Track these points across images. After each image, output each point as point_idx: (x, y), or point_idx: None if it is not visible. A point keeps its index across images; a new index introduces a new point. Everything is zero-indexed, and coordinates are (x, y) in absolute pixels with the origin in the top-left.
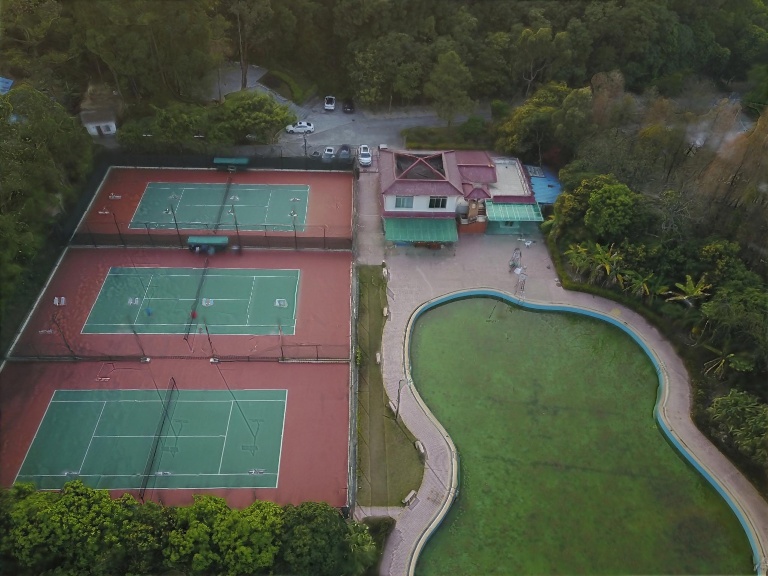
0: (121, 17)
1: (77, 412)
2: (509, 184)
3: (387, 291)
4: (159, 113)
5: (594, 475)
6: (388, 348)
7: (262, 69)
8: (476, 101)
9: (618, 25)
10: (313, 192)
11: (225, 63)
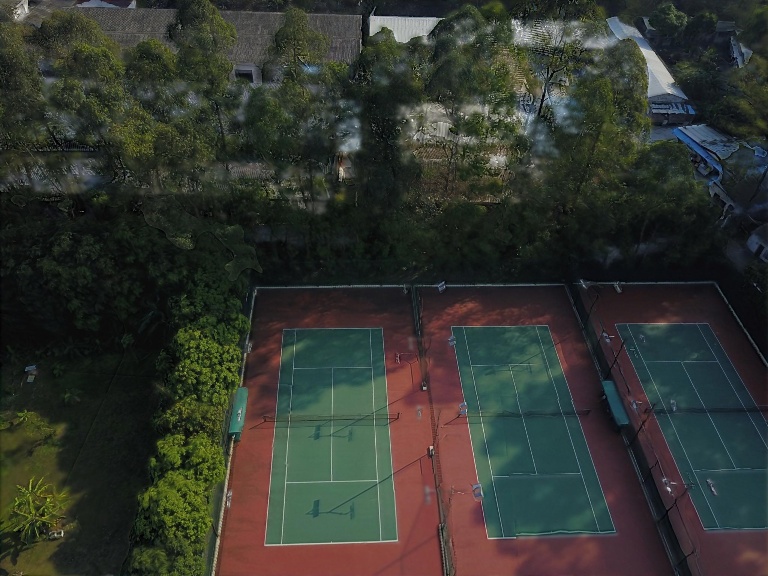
0: None
1: (359, 349)
2: None
3: None
4: None
5: None
6: None
7: None
8: None
9: None
10: None
11: None
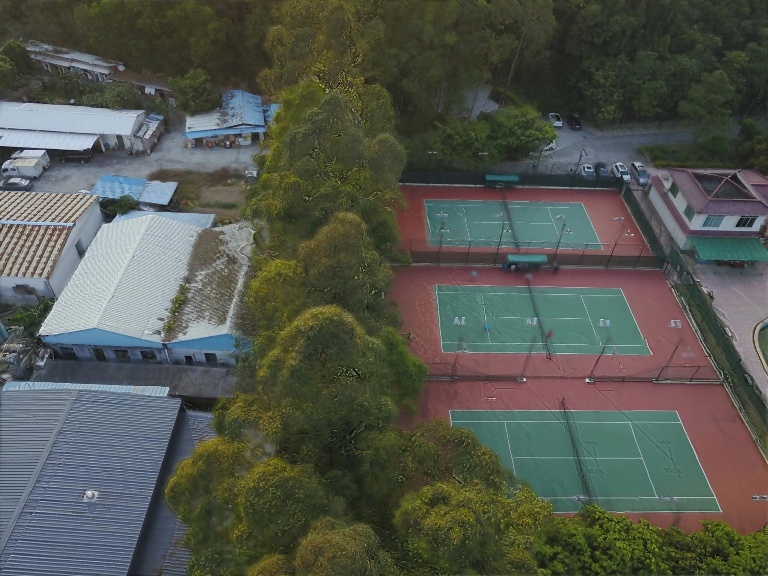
0: (433, 36)
1: (483, 433)
2: None
3: (716, 311)
4: (443, 130)
5: None
6: (750, 369)
7: None
8: (730, 120)
9: None
10: (590, 210)
11: (487, 81)
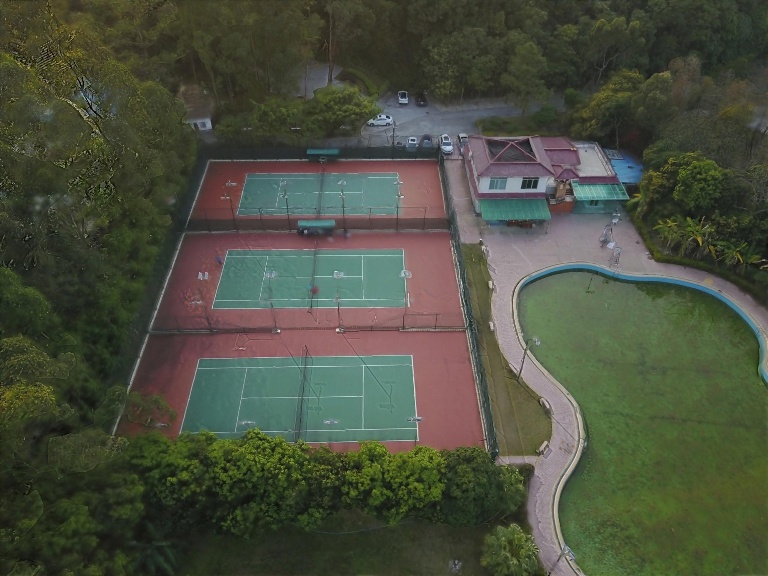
0: (229, 18)
1: (223, 377)
2: (591, 166)
3: (488, 267)
4: (258, 108)
5: (710, 427)
6: (499, 317)
7: (337, 67)
8: (551, 90)
9: (681, 14)
10: (403, 179)
11: (313, 60)
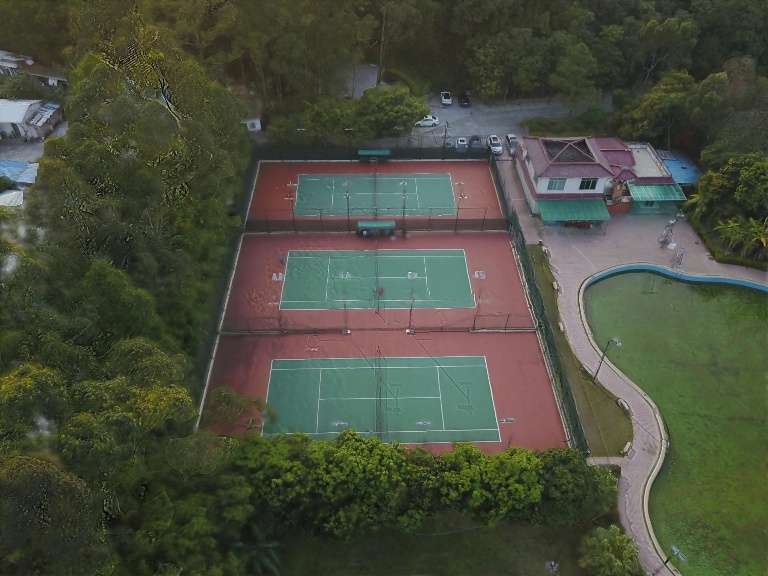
0: (287, 19)
1: (298, 378)
2: (645, 167)
3: (550, 267)
4: (311, 108)
5: None
6: (567, 318)
7: None
8: (599, 90)
9: (726, 15)
10: (455, 179)
11: (362, 61)
